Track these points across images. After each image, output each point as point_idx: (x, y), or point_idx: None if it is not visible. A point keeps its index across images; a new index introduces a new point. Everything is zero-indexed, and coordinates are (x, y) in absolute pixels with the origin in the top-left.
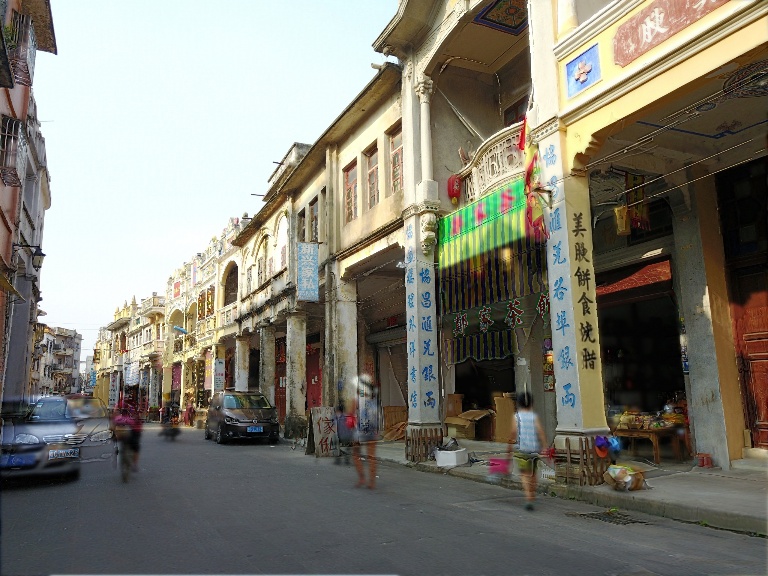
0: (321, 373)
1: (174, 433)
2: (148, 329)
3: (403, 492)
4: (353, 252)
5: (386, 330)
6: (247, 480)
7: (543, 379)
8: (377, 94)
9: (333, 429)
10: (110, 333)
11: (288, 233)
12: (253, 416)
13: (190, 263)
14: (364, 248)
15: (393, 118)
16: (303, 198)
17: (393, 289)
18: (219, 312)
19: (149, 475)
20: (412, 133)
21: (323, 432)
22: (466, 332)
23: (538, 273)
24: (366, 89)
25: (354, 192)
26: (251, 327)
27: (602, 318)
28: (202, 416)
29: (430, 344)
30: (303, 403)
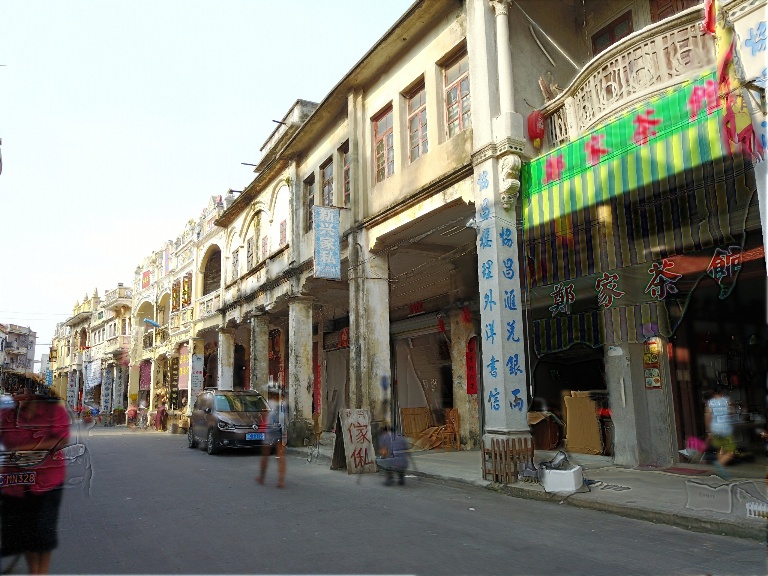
0: (320, 370)
1: (147, 440)
2: (112, 324)
3: (558, 543)
4: (389, 216)
5: (408, 318)
6: (295, 520)
7: (644, 373)
8: (427, 14)
9: (367, 437)
10: (68, 329)
11: (291, 204)
12: (251, 420)
13: (162, 249)
14: (406, 210)
15: (450, 42)
16: (311, 161)
17: (446, 260)
18: (197, 302)
19: (140, 509)
20: (485, 53)
21: (355, 441)
22: (573, 309)
23: (711, 219)
24: (415, 6)
25: (387, 144)
26: (239, 317)
27: (730, 294)
28: (176, 419)
29: (514, 326)
30: (310, 404)
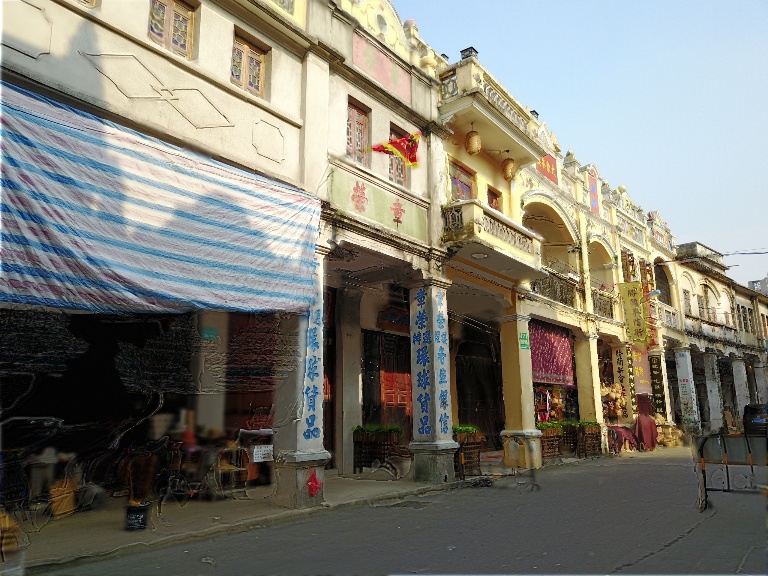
0: None
1: None
2: (382, 113)
3: None
4: None
5: None
6: None
7: None
8: None
9: None
10: None
11: None
12: None
13: None
14: None
15: (767, 314)
16: None
17: None
18: None
19: None
20: None
21: None
22: None
23: None
24: None
25: None
26: None
27: None
28: None
29: None
30: None
